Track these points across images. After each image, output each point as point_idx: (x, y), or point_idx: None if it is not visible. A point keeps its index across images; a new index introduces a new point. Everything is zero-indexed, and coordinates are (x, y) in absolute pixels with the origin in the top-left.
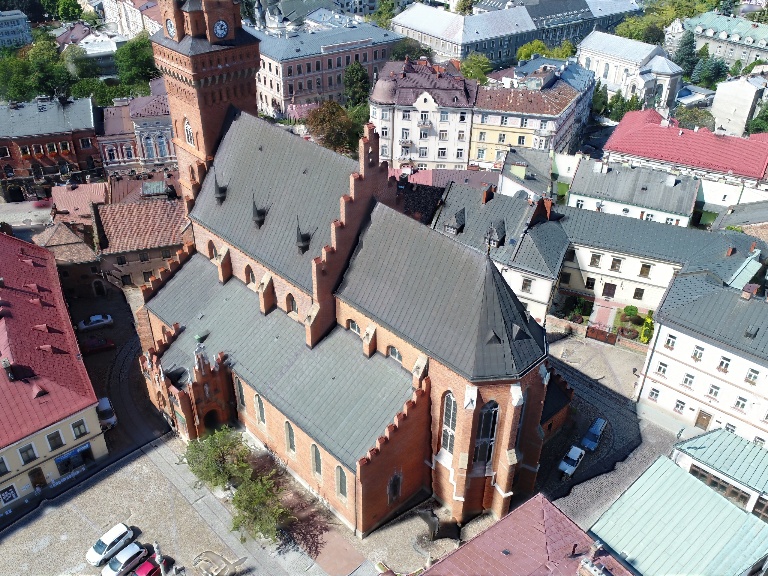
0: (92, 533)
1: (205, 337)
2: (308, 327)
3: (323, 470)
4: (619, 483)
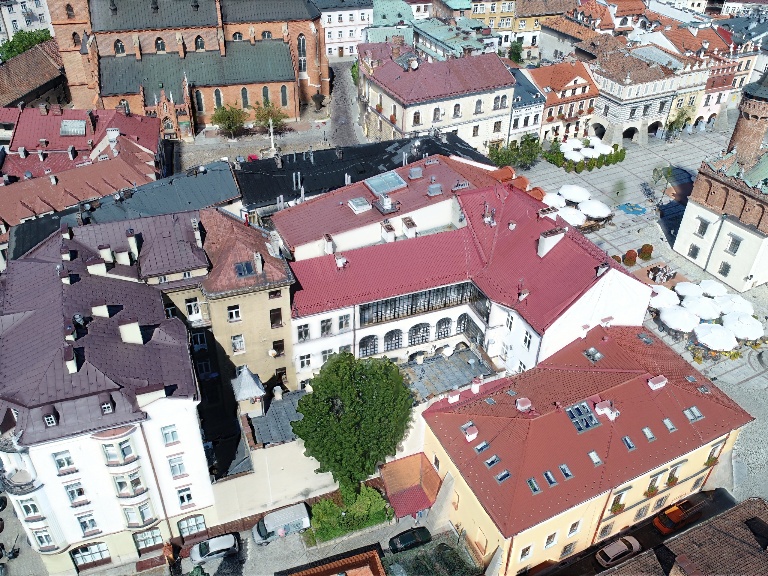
0: None
1: (162, 84)
2: (222, 43)
3: (272, 99)
4: (342, 77)
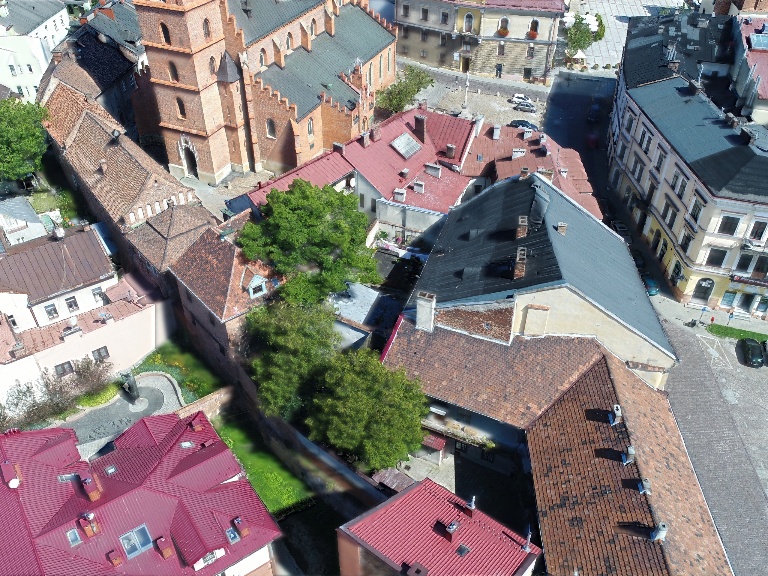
0: None
1: None
2: None
3: None
4: None
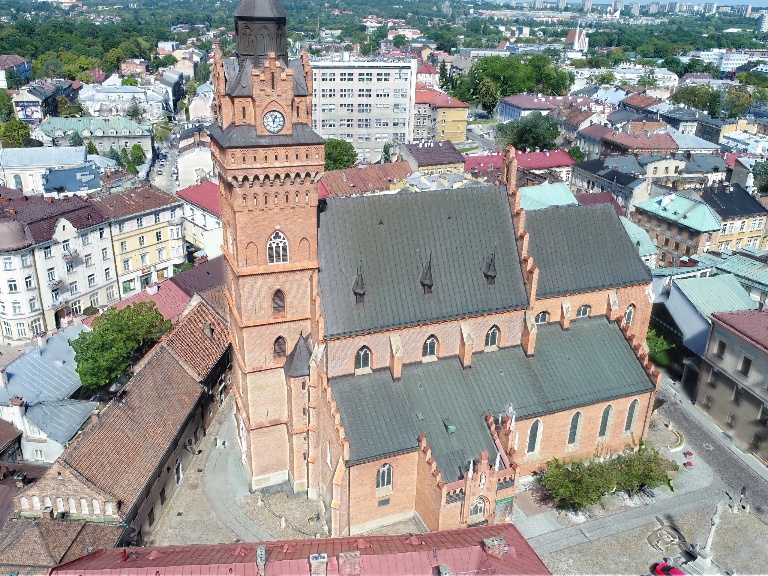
0: None
1: None
2: (534, 335)
3: (613, 424)
4: None
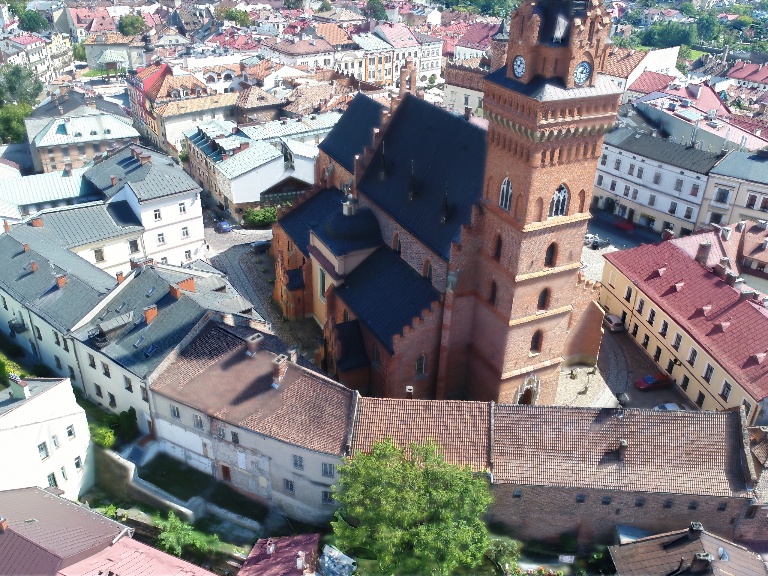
0: (590, 275)
1: None
2: None
3: None
4: None
